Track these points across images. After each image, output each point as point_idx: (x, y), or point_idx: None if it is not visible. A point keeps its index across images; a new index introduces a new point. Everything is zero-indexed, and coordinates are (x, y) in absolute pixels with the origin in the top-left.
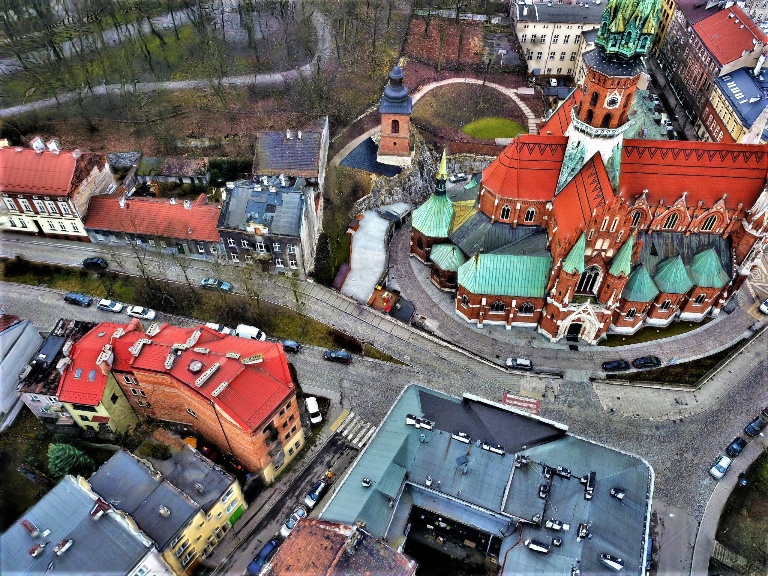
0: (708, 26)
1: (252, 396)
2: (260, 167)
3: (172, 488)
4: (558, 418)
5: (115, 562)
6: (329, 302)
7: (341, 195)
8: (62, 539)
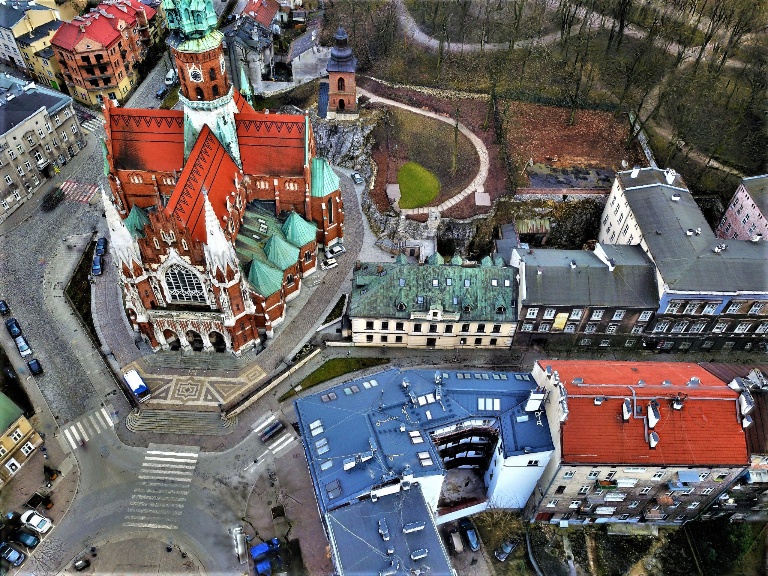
0: (676, 368)
1: (67, 36)
2: (295, 40)
3: (43, 37)
4: (70, 210)
5: (7, 22)
6: None
7: (296, 95)
8: (20, 7)
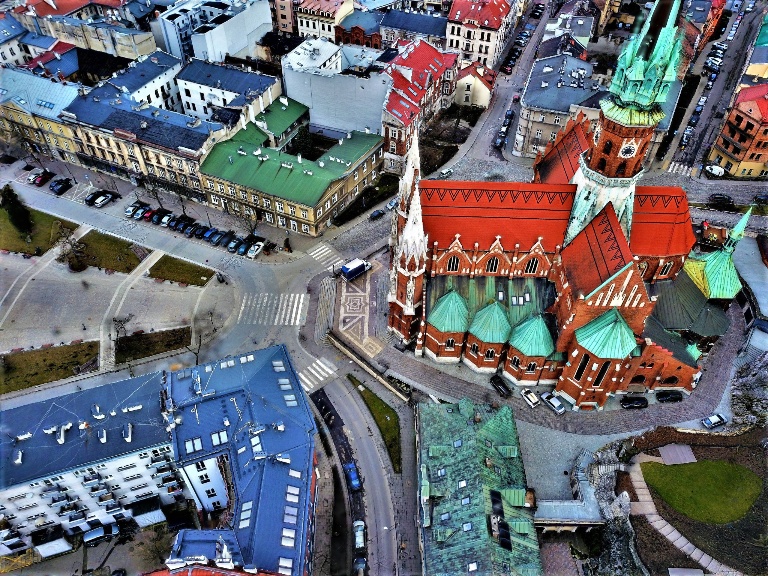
0: None
1: None
2: None
3: None
4: None
5: (759, 59)
6: (759, 228)
7: None
8: None
